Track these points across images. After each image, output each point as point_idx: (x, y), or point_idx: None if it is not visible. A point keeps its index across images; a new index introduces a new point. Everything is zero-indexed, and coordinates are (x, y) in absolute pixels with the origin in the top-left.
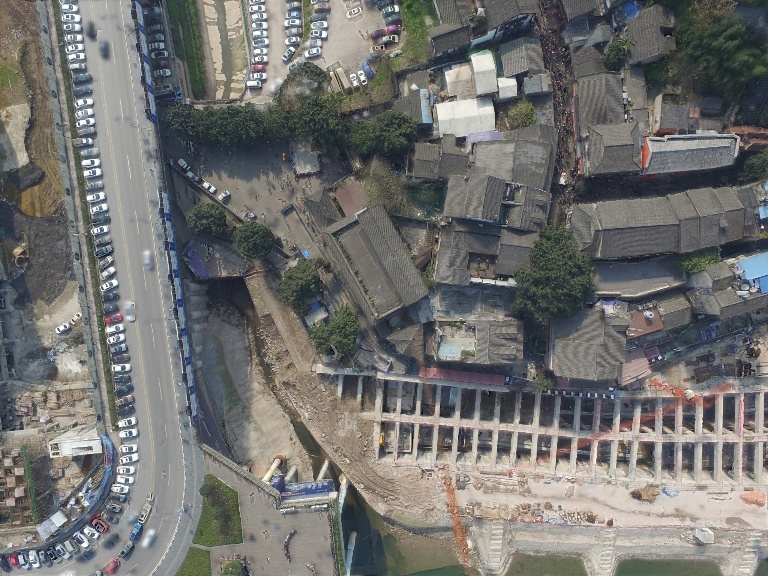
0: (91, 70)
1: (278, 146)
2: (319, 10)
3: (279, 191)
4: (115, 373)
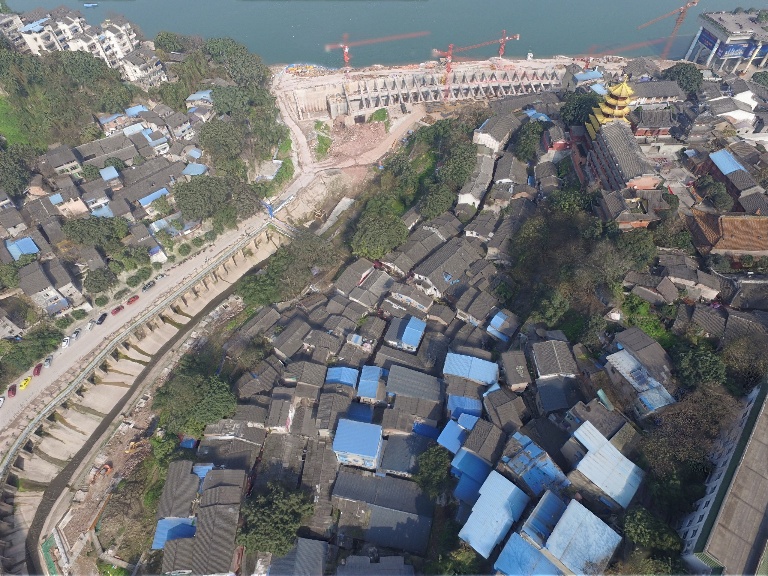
0: None
1: None
2: None
3: None
4: None
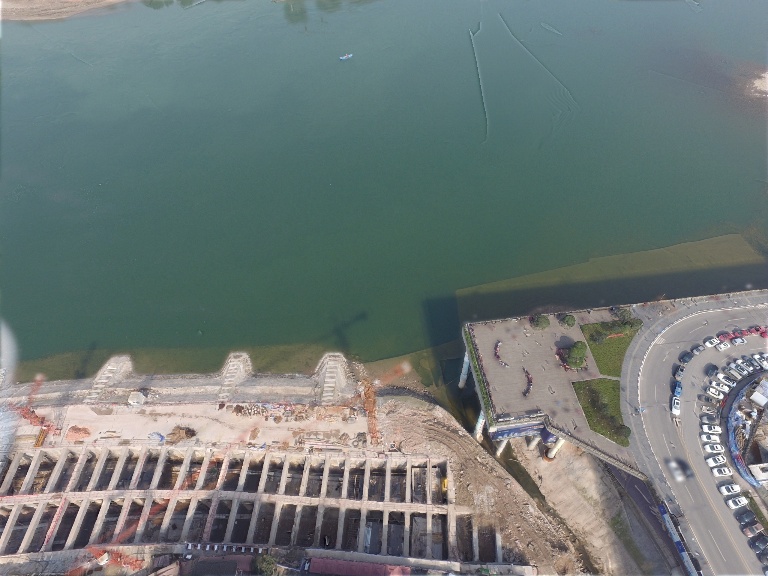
0: None
1: None
2: None
3: None
4: None
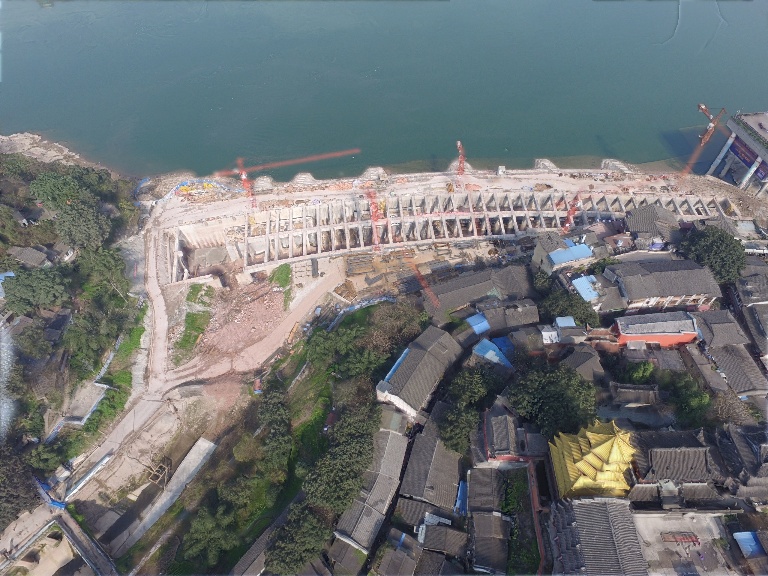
0: None
1: None
2: None
3: None
4: None
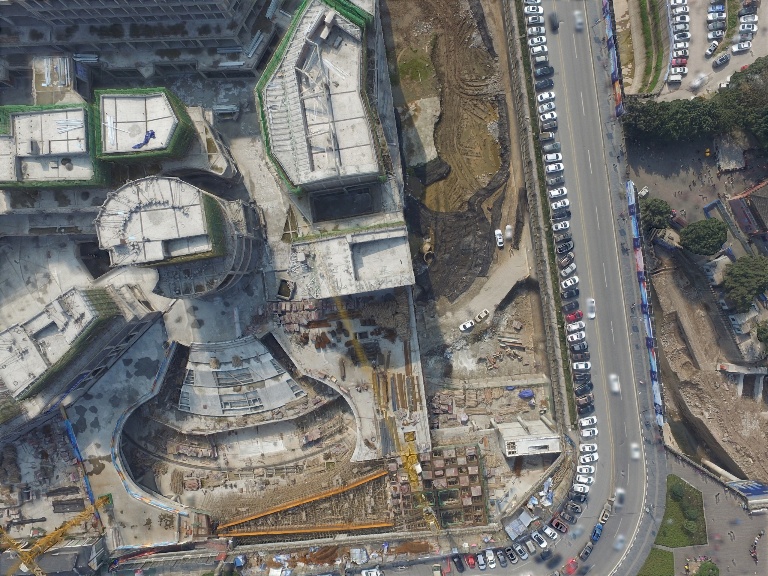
0: (552, 63)
1: (699, 141)
2: (751, 3)
3: (700, 187)
4: (574, 371)
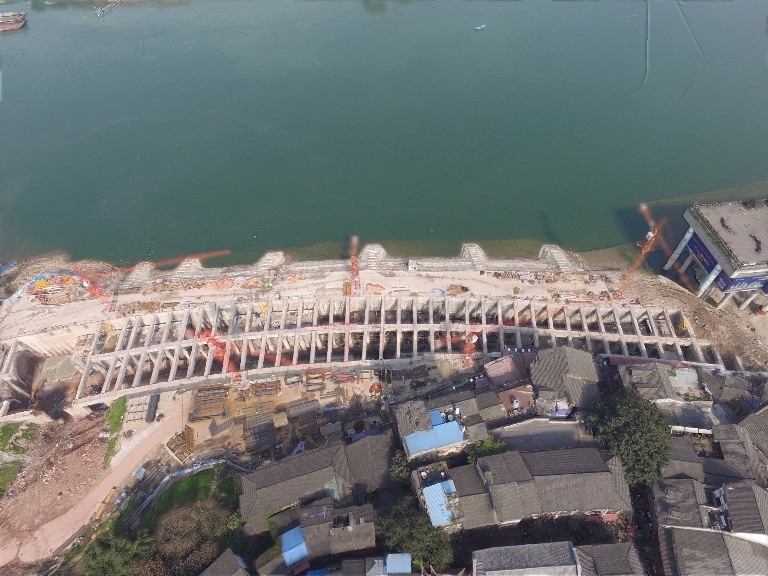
0: None
1: None
2: None
3: None
4: None
